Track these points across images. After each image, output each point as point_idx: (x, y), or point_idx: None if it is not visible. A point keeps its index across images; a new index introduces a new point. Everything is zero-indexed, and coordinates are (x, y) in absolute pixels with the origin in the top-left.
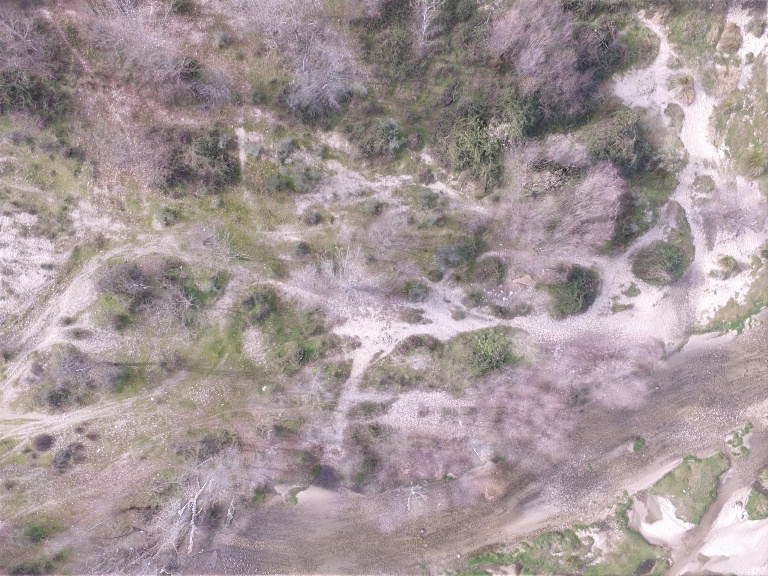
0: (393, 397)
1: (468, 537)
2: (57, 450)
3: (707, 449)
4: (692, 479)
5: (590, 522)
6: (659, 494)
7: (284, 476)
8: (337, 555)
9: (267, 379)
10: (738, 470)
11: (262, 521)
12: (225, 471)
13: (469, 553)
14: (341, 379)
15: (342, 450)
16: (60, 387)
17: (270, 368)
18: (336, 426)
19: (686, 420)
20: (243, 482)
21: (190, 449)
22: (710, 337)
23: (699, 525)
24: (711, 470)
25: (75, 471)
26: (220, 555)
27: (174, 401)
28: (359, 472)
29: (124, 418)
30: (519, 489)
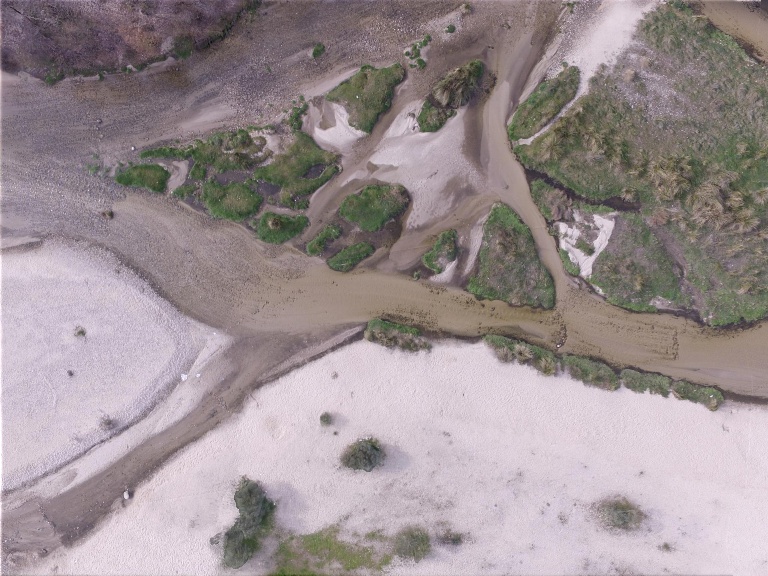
0: None
1: (144, 131)
2: None
3: (386, 60)
4: (367, 87)
5: (265, 125)
6: (334, 101)
7: None
8: (13, 139)
9: None
10: (414, 82)
11: None
12: None
13: (144, 147)
14: None
15: (23, 31)
16: None
17: None
18: (17, 5)
19: (367, 30)
20: None
21: None
22: None
23: (371, 134)
24: (385, 78)
25: None
26: None
27: None
28: (35, 51)
29: None
30: (198, 88)
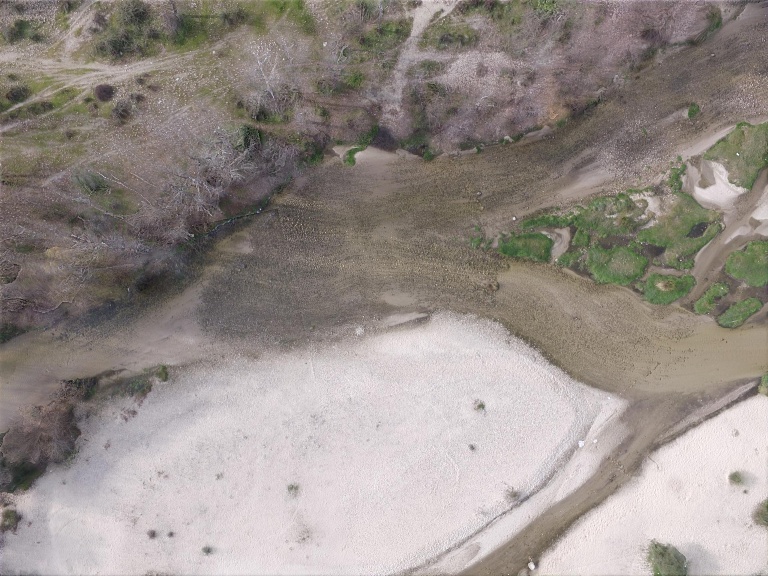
0: (453, 57)
1: (523, 201)
2: (118, 101)
3: (760, 116)
4: (745, 144)
5: (644, 187)
6: (713, 159)
7: (343, 135)
8: (394, 216)
9: (328, 37)
10: None
11: (320, 181)
12: (285, 126)
13: (524, 216)
14: (401, 37)
15: (401, 110)
16: (123, 35)
17: (331, 25)
18: (396, 85)
19: (740, 87)
20: (303, 137)
21: (252, 99)
22: (766, 5)
23: (751, 190)
24: (765, 134)
25: (136, 122)
26: (278, 215)
27: (236, 55)
28: (418, 128)
29: (186, 71)
30: (575, 154)
